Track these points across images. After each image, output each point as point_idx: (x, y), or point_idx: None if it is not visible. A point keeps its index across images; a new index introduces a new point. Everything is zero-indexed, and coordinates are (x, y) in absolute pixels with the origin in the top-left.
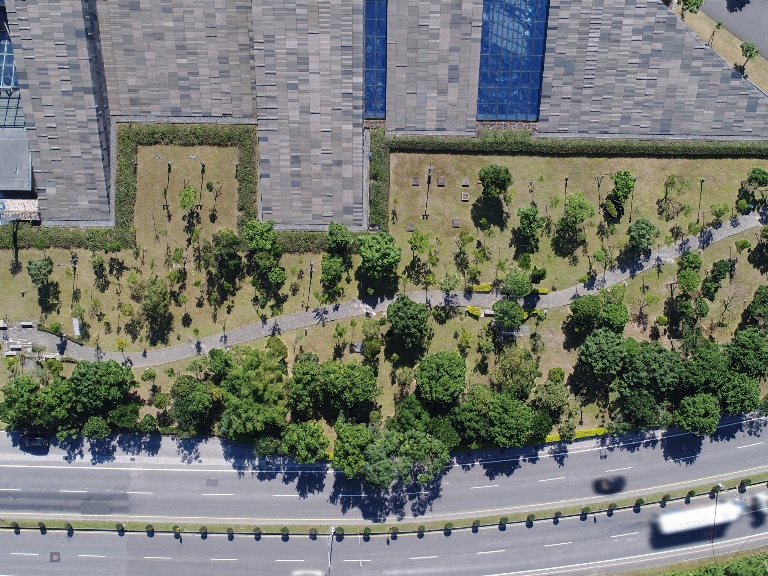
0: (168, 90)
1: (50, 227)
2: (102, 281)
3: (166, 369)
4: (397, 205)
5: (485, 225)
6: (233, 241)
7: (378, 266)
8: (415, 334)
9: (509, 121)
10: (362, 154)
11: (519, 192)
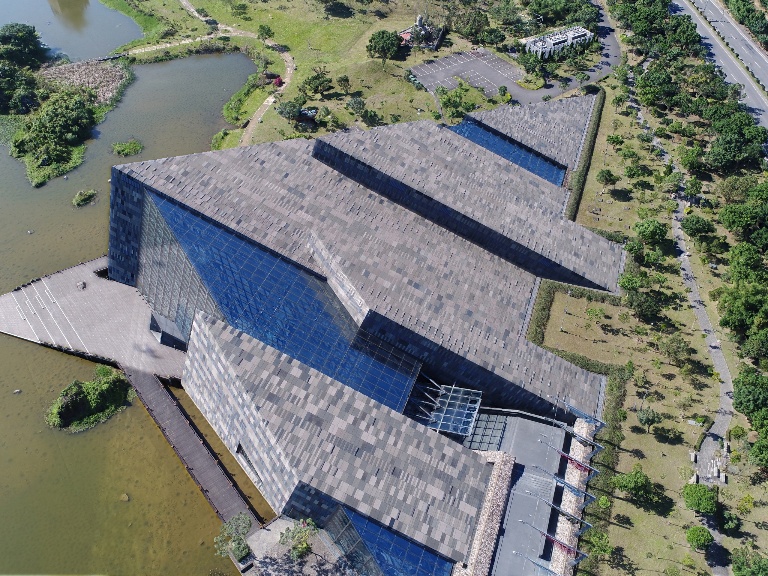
0: (507, 312)
1: (603, 419)
2: (655, 396)
3: (735, 372)
4: (611, 230)
5: (629, 198)
6: None
7: (660, 227)
8: (708, 222)
9: None
10: None
11: None
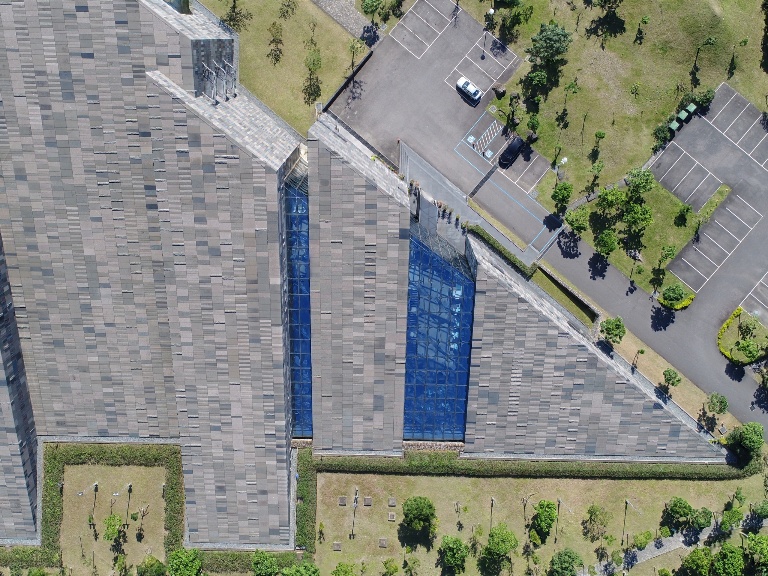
0: (94, 414)
1: None
2: None
3: None
4: (324, 525)
5: (411, 545)
6: (157, 574)
7: None
8: None
9: (436, 440)
10: (287, 483)
11: (445, 512)
